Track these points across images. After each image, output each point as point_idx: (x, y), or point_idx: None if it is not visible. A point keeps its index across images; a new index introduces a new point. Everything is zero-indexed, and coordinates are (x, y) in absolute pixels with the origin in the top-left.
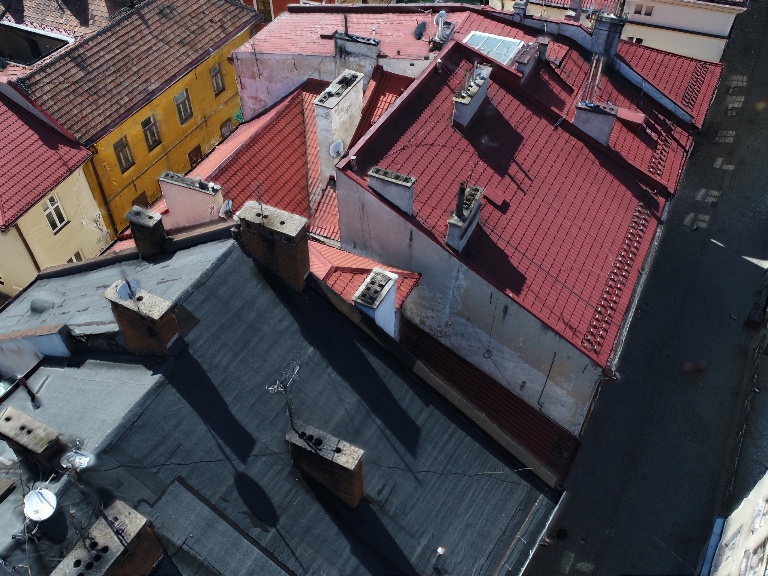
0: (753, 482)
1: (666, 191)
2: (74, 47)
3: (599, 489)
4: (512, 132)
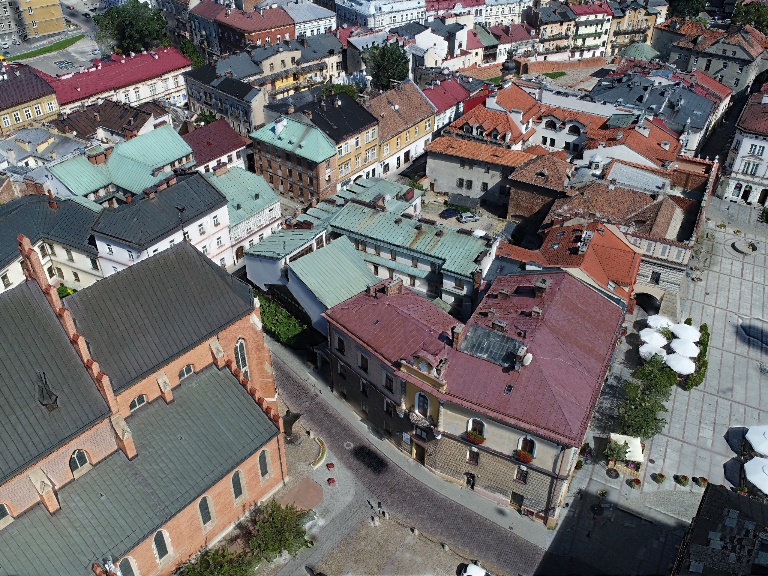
0: None
1: None
2: None
3: None
4: None
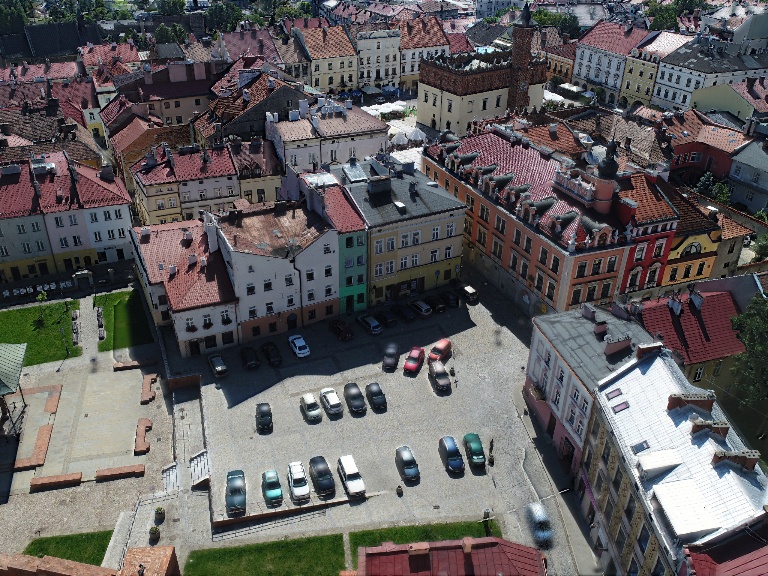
0: (22, 302)
1: (42, 211)
2: (25, 146)
3: (1, 289)
4: (17, 181)
